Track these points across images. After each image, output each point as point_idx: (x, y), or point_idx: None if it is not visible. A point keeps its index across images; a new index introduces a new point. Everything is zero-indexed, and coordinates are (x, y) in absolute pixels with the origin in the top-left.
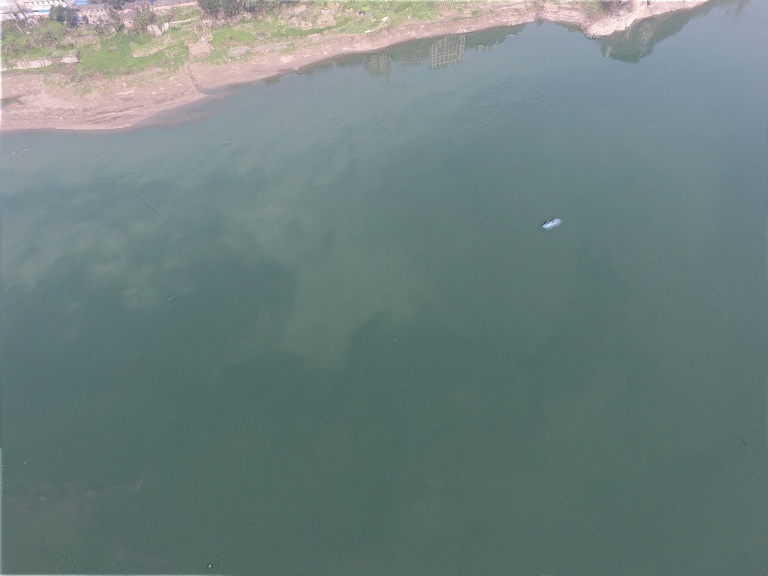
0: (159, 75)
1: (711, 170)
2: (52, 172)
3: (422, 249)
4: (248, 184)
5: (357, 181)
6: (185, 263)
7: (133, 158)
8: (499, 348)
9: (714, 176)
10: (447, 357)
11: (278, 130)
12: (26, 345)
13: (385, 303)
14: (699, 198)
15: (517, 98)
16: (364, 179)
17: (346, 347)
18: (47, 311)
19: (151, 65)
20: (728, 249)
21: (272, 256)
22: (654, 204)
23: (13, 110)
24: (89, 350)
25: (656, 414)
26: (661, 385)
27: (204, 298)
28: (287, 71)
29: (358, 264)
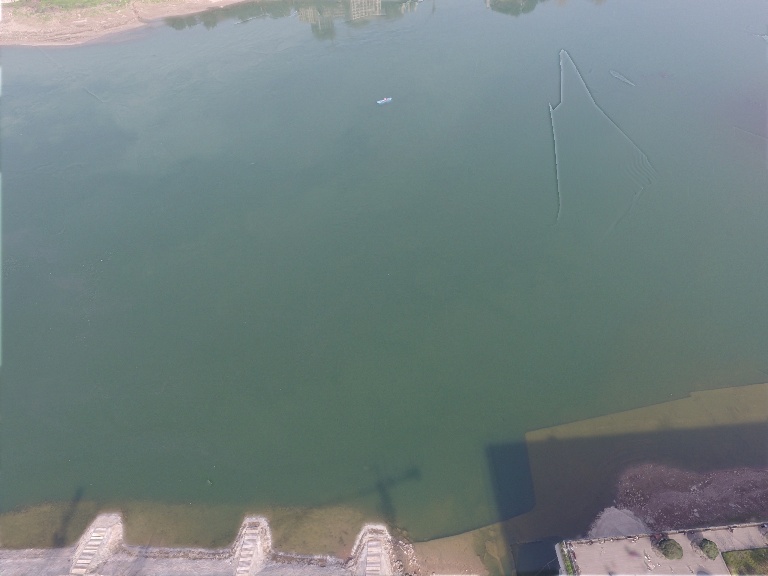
0: (108, 9)
1: (510, 67)
2: (16, 73)
3: (287, 116)
4: (168, 80)
5: (252, 79)
6: (112, 125)
7: (81, 65)
8: (322, 166)
9: (511, 71)
10: (285, 171)
11: (198, 47)
12: None
13: (251, 145)
14: (493, 83)
15: (393, 28)
16: (258, 78)
17: (217, 167)
18: (7, 149)
19: (102, 1)
20: (503, 114)
21: (177, 121)
22: (457, 85)
23: None
24: (35, 167)
25: None
26: (419, 180)
27: (120, 138)
28: (214, 8)
29: (238, 125)
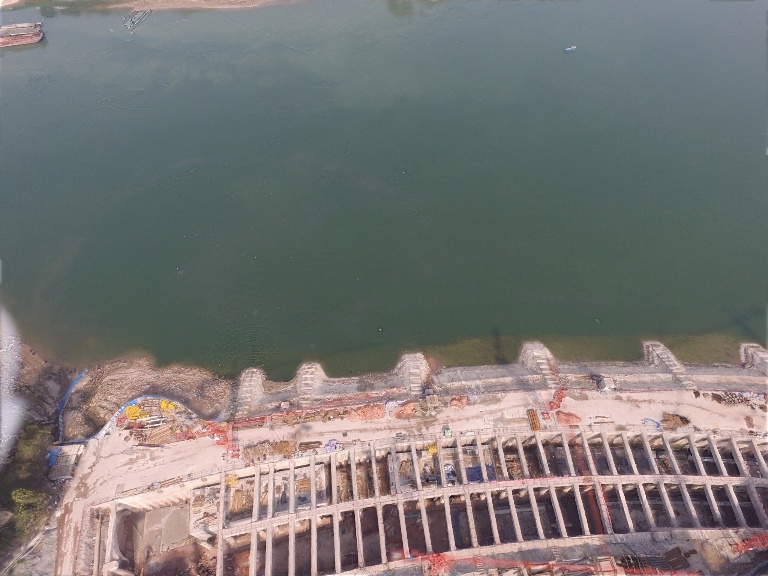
0: None
1: (673, 20)
2: (212, 31)
3: (487, 63)
4: (357, 36)
5: (433, 34)
6: (330, 72)
7: (267, 24)
8: (545, 101)
9: (675, 23)
10: (514, 105)
11: (368, 8)
12: (250, 101)
13: (469, 86)
14: (665, 33)
15: None
16: (438, 33)
17: (450, 103)
18: (252, 91)
19: None
20: (683, 58)
21: (387, 69)
22: (636, 34)
23: None
24: (291, 104)
25: (639, 118)
26: (642, 109)
27: (356, 80)
28: None
29: (447, 70)
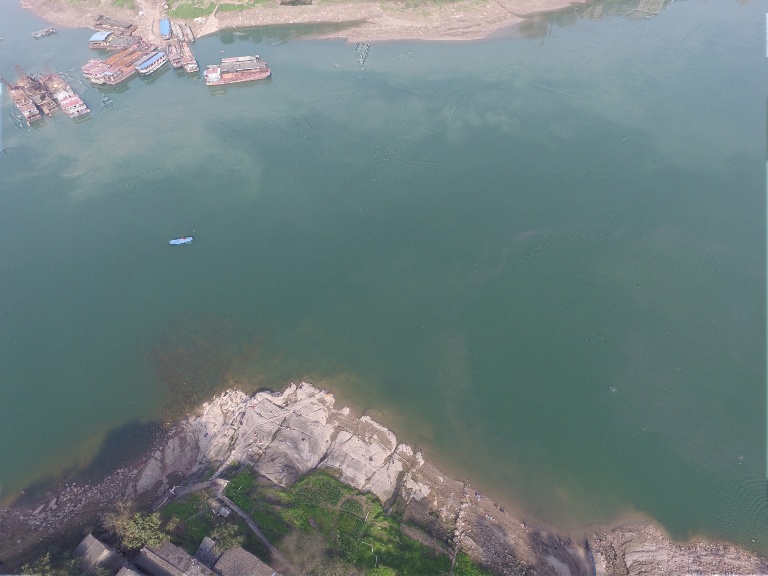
0: (477, 4)
1: None
2: (447, 67)
3: None
4: (614, 75)
5: (700, 74)
6: (613, 120)
7: (502, 59)
8: None
9: None
10: None
11: (605, 42)
12: (557, 158)
13: None
14: None
15: None
16: (705, 73)
17: None
18: (543, 143)
19: None
20: None
21: (676, 117)
22: None
23: (372, 27)
24: (603, 162)
25: None
26: None
27: (665, 133)
28: (577, 4)
29: (751, 120)
